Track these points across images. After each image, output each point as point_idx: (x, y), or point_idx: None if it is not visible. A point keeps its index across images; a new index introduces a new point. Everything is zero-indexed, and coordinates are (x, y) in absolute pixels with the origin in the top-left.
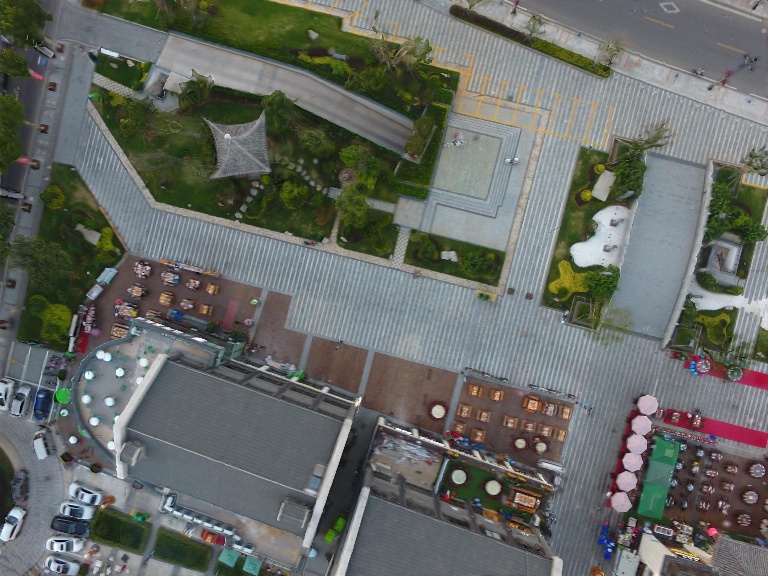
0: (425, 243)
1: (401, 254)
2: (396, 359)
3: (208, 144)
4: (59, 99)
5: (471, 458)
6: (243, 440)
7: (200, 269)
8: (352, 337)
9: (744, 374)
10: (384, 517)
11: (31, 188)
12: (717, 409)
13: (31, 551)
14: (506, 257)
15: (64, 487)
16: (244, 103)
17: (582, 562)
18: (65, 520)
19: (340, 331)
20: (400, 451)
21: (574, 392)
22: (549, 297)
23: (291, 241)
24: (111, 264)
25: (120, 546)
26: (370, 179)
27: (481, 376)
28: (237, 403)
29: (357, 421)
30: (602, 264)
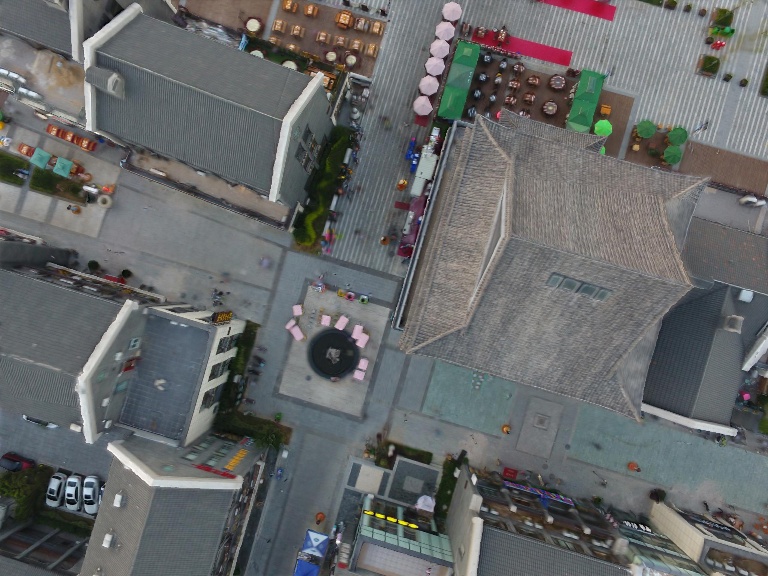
0: None
1: None
2: None
3: None
4: None
5: None
6: None
7: None
8: None
9: None
10: (151, 27)
11: None
12: (524, 28)
13: None
14: None
15: None
16: None
17: (389, 177)
18: None
19: None
20: None
21: (387, 11)
22: None
23: None
24: None
25: None
26: None
27: None
28: None
29: None
30: None
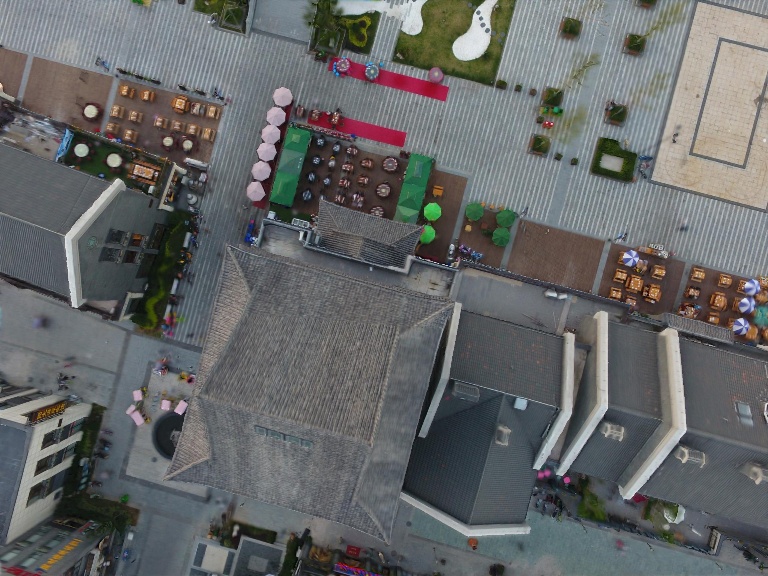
0: None
1: None
2: (54, 63)
3: None
4: None
5: (97, 135)
6: None
7: None
8: (12, 42)
9: (385, 76)
10: None
11: None
12: (359, 110)
13: None
14: None
15: None
16: None
17: None
18: None
19: (1, 36)
20: (28, 128)
21: (224, 94)
22: (200, 1)
23: None
24: None
25: None
26: None
27: (135, 79)
28: None
29: None
30: None
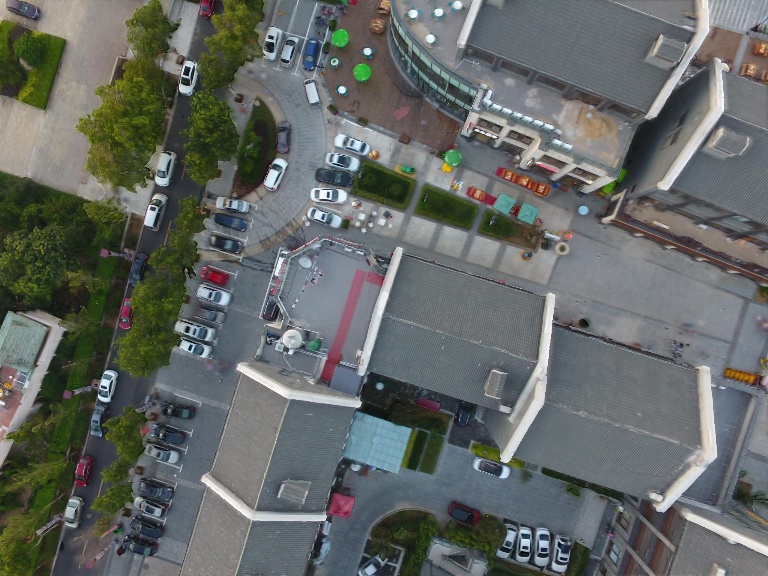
0: None
1: None
2: None
3: None
4: None
5: None
6: None
7: None
8: None
9: None
10: (738, 84)
11: None
12: None
13: (289, 206)
14: None
15: (326, 142)
16: None
17: None
18: (331, 170)
19: None
20: None
21: None
22: None
23: None
24: None
25: (384, 200)
26: None
27: (766, 38)
28: None
29: None
30: None
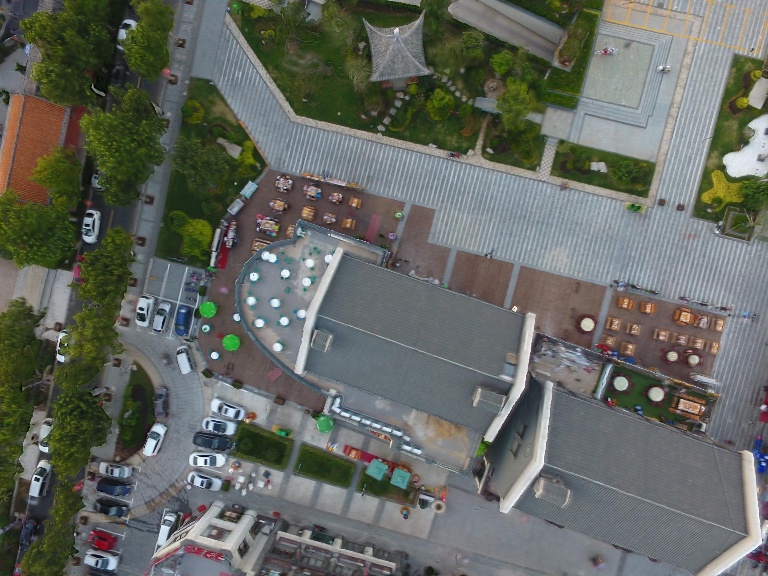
0: (578, 151)
1: (548, 166)
2: (542, 272)
3: (353, 54)
4: (196, 13)
5: (632, 365)
6: (431, 329)
7: (343, 182)
8: (497, 251)
9: None
10: (570, 410)
11: (169, 103)
12: None
13: (171, 468)
14: (656, 168)
15: (204, 404)
16: (388, 12)
17: None
18: (208, 435)
19: (485, 245)
20: (559, 358)
21: (726, 305)
22: (701, 208)
23: (435, 154)
24: (251, 179)
25: (262, 462)
26: (524, 85)
27: (630, 289)
28: (419, 296)
29: None
30: (756, 174)
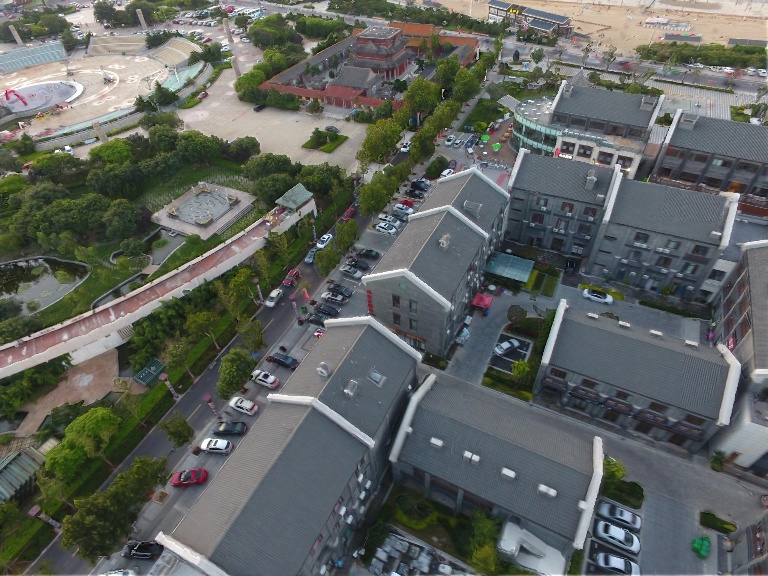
0: (665, 113)
1: None
2: None
3: None
4: None
5: None
6: None
7: None
8: None
9: None
10: None
11: (470, 102)
12: None
13: None
14: None
15: None
16: None
17: None
18: None
19: None
20: None
21: None
22: None
23: None
24: None
25: None
26: None
27: None
28: None
29: (643, 159)
30: None
